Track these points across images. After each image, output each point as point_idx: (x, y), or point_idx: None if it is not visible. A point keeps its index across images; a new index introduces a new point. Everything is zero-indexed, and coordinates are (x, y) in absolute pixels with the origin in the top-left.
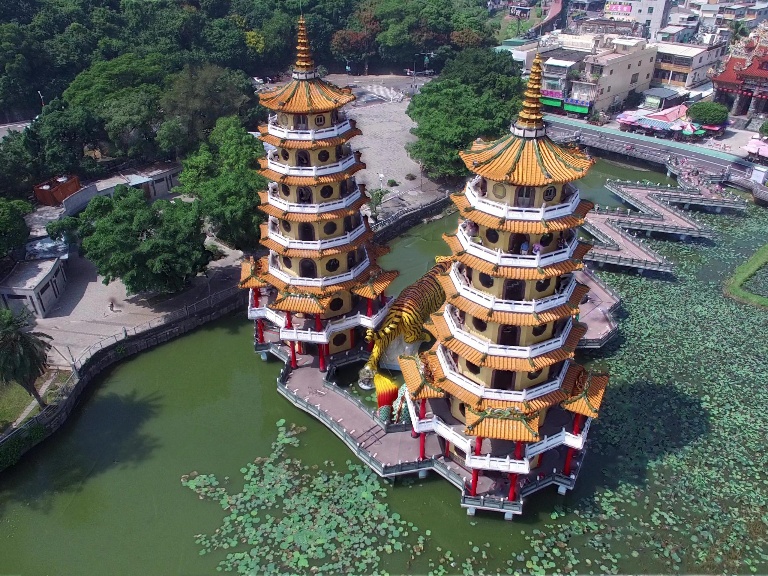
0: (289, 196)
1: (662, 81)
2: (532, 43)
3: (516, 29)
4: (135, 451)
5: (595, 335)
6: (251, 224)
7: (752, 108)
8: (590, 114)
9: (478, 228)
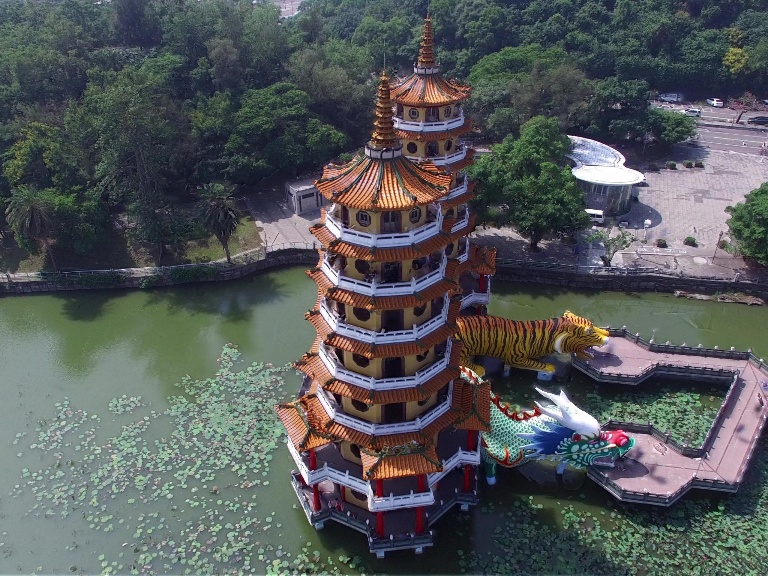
0: None
1: None
2: None
3: None
4: (236, 314)
5: (636, 486)
6: None
7: None
8: None
9: None
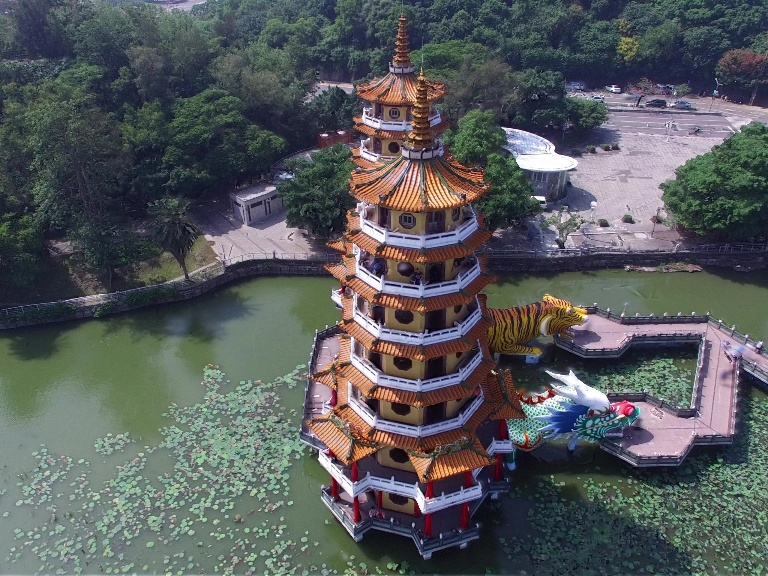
0: None
1: None
2: None
3: None
4: (207, 334)
5: (647, 452)
6: None
7: None
8: None
9: None
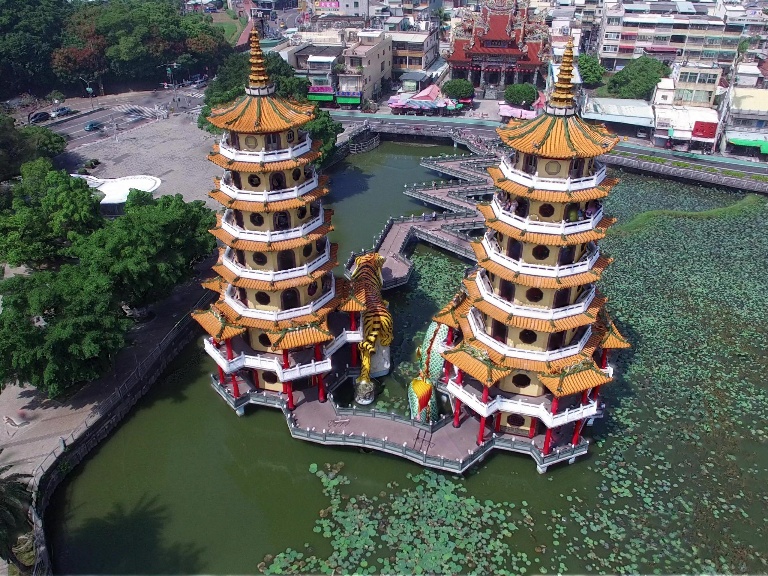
0: (263, 225)
1: (401, 66)
2: (283, 43)
3: (261, 31)
4: (178, 567)
5: None
6: (157, 274)
7: (483, 80)
8: (361, 104)
9: (527, 207)
